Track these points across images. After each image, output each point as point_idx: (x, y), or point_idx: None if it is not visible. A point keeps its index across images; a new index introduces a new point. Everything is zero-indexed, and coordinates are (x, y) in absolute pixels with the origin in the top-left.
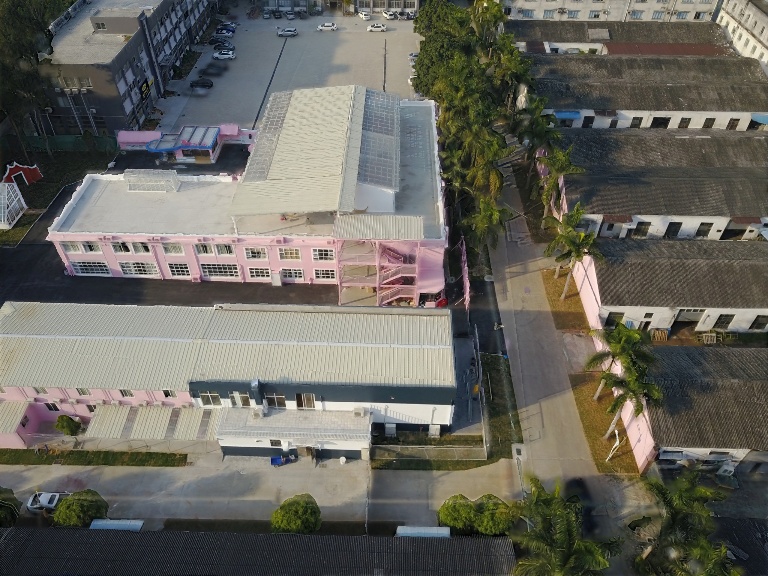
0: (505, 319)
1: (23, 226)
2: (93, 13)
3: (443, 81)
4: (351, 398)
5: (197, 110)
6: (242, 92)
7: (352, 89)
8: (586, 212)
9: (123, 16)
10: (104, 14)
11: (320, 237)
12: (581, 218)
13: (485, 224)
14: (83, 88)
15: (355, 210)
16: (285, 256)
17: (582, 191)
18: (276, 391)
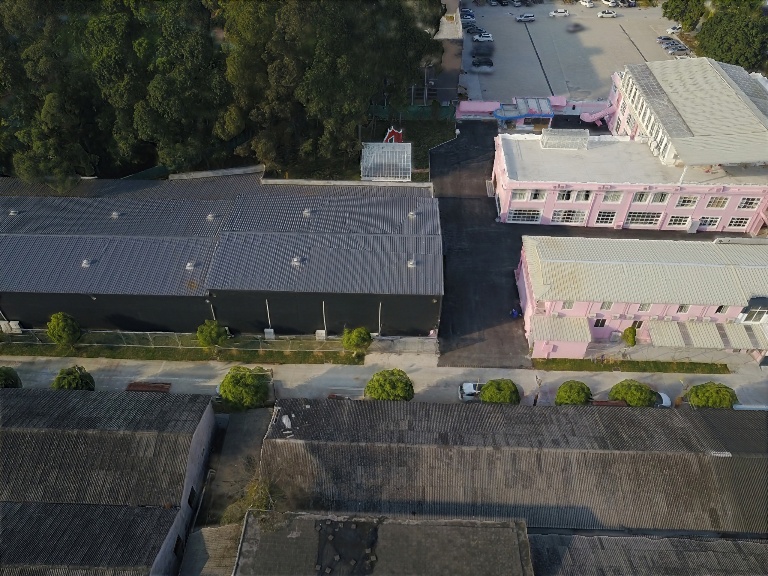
0: None
1: None
2: None
3: None
4: None
5: (493, 86)
6: (521, 70)
7: (706, 61)
8: None
9: None
10: None
11: (756, 186)
12: None
13: None
14: None
15: (765, 165)
16: (711, 205)
17: None
18: None
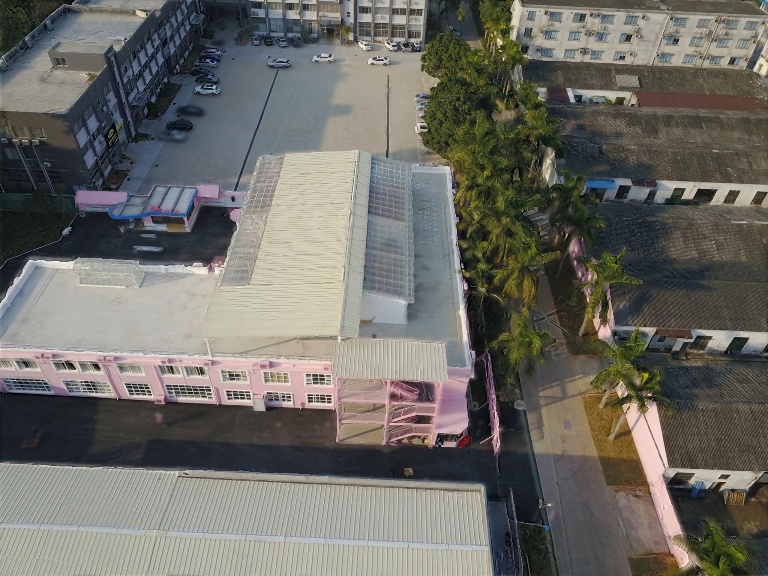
0: (543, 468)
1: None
2: (52, 46)
3: (462, 147)
4: None
5: (173, 159)
6: (226, 136)
7: (355, 156)
8: (637, 324)
9: (87, 51)
10: (65, 47)
11: (315, 362)
12: (630, 330)
13: None
14: (35, 139)
15: None
16: (271, 379)
17: (631, 296)
18: None
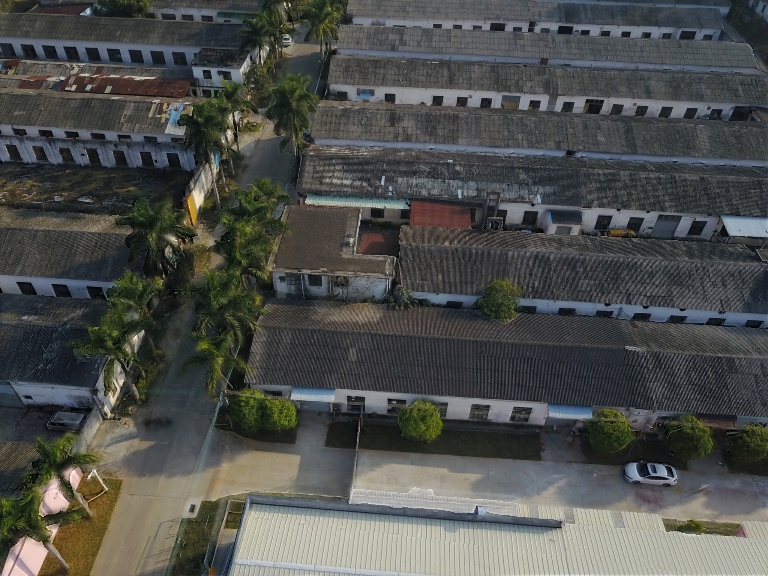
0: None
1: None
2: None
3: None
4: None
5: None
6: None
7: None
8: None
9: None
10: None
11: None
12: None
13: None
14: None
15: None
16: None
17: None
18: None
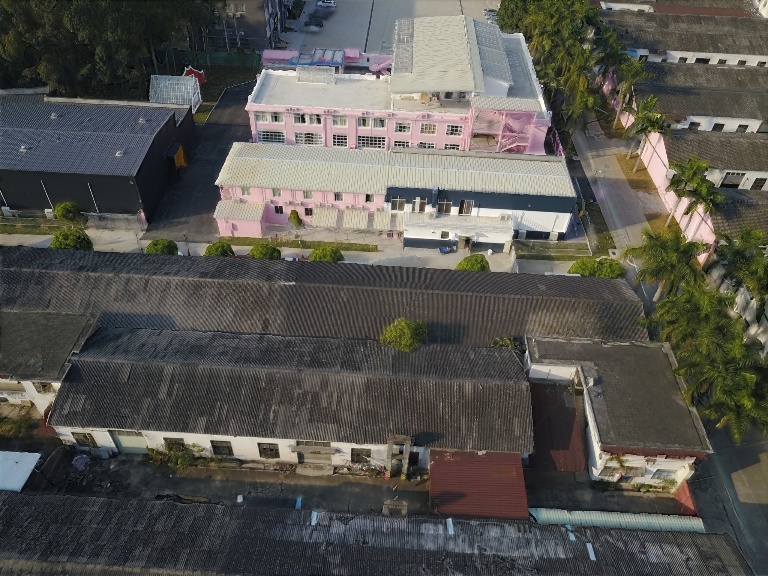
0: (592, 182)
1: (203, 112)
2: None
3: None
4: (499, 206)
5: (315, 42)
6: (348, 32)
7: (463, 18)
8: (651, 112)
9: None
10: None
11: (455, 114)
12: None
13: (580, 109)
14: (237, 13)
15: None
16: (424, 131)
17: (648, 97)
18: (447, 197)
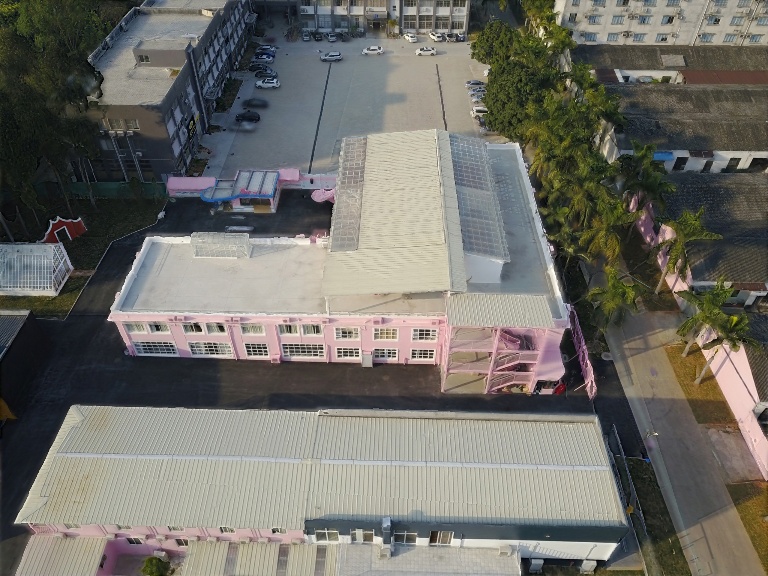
0: (636, 410)
1: (71, 292)
2: (136, 45)
3: (532, 123)
4: (497, 535)
5: (246, 148)
6: (292, 126)
7: (434, 134)
8: (713, 279)
9: (169, 48)
10: (147, 45)
11: (424, 317)
12: (706, 285)
13: None
14: (129, 130)
15: None
16: (380, 336)
17: (706, 254)
18: (408, 529)
